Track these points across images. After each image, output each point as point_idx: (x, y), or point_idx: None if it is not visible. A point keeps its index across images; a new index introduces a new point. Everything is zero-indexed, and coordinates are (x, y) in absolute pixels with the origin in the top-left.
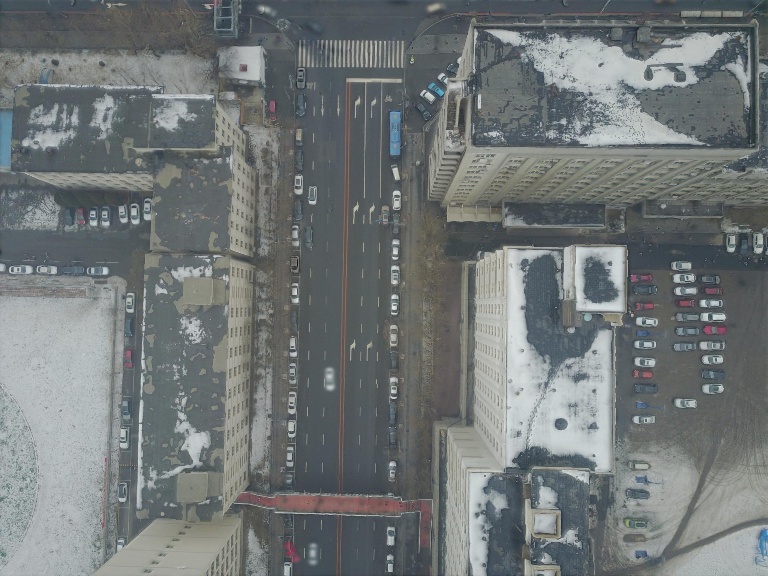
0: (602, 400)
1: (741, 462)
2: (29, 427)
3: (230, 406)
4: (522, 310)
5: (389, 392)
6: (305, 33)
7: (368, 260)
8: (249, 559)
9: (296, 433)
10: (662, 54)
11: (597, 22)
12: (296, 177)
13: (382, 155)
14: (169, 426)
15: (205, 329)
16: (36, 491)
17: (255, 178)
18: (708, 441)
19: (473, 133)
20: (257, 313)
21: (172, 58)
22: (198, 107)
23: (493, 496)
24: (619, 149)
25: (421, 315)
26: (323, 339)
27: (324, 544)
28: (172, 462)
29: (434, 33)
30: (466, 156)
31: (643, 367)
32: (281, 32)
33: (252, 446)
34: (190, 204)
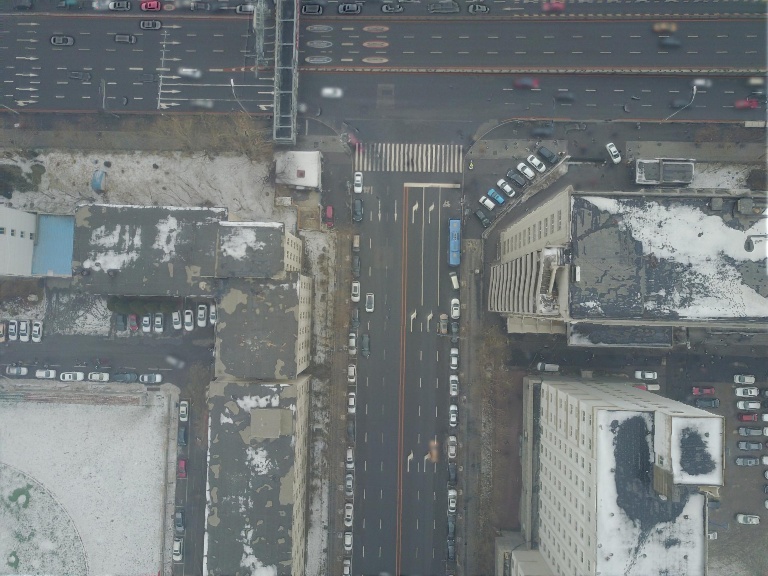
0: (694, 566)
1: None
2: (80, 537)
3: (293, 532)
4: (612, 473)
5: (447, 505)
6: (362, 136)
7: (426, 369)
8: None
9: (352, 545)
10: (763, 224)
11: (697, 192)
12: (353, 284)
13: (440, 261)
14: (234, 559)
15: (271, 460)
16: None
17: (311, 284)
18: None
19: (569, 303)
20: (313, 422)
21: (227, 161)
22: (267, 235)
23: None
24: (720, 323)
25: (480, 426)
26: (380, 449)
27: None
28: None
29: (493, 138)
30: None
31: None
32: (338, 135)
33: (308, 558)
34: (256, 331)
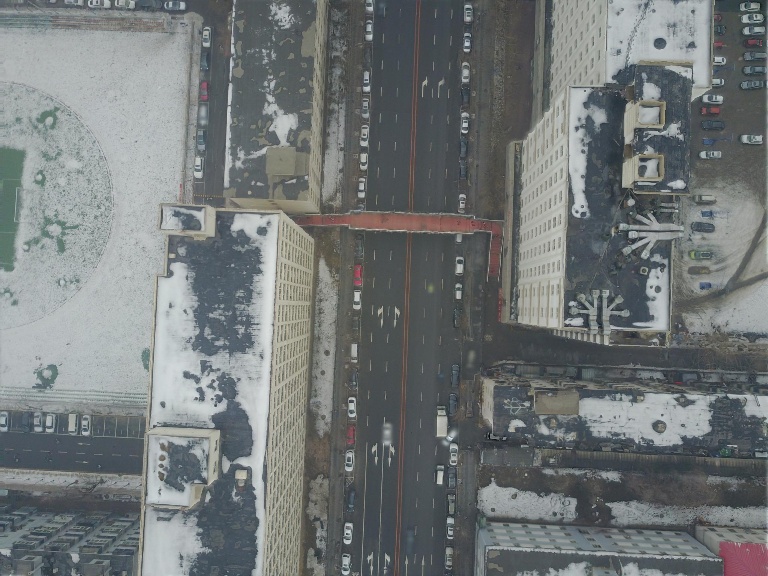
0: (700, 20)
1: None
2: (105, 157)
3: (313, 105)
4: None
5: (460, 127)
6: None
7: (441, 0)
8: (319, 287)
9: (368, 166)
10: None
11: None
12: None
13: None
14: (257, 108)
15: (294, 15)
16: (110, 219)
17: None
18: None
19: None
20: (331, 50)
21: None
22: None
23: (592, 111)
24: None
25: (493, 53)
26: (395, 76)
27: (393, 274)
28: (260, 143)
29: None
30: None
31: (711, 104)
32: None
33: (324, 178)
34: None
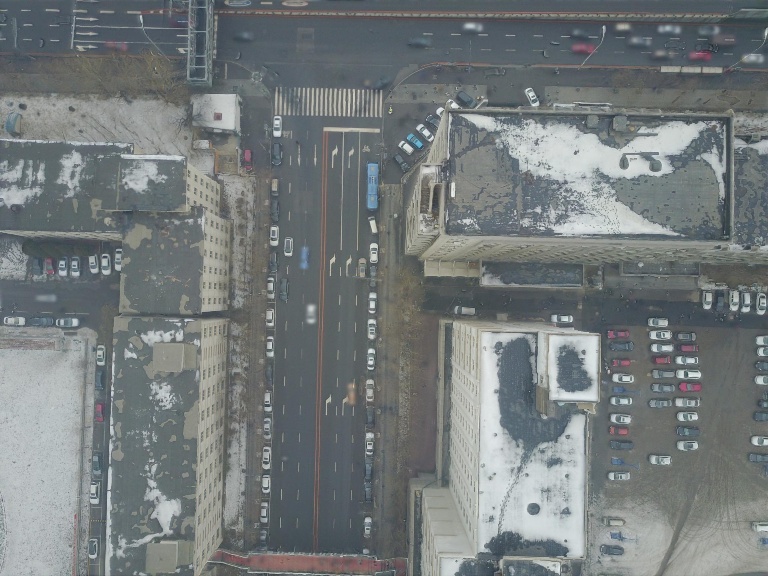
0: (574, 485)
1: (714, 518)
2: None
3: (202, 469)
4: (495, 394)
5: (365, 447)
6: (282, 80)
7: (344, 313)
8: None
9: (270, 488)
10: (638, 142)
11: (573, 109)
12: (272, 228)
13: (359, 206)
14: (138, 494)
15: (176, 395)
16: (4, 547)
17: (230, 229)
18: (682, 497)
19: (447, 220)
20: (231, 366)
21: (145, 104)
22: (169, 169)
23: None
24: (594, 239)
25: (398, 369)
26: (298, 393)
27: None
28: (141, 530)
29: (413, 82)
30: (440, 239)
31: (619, 423)
32: None
33: (226, 501)
34: (161, 266)
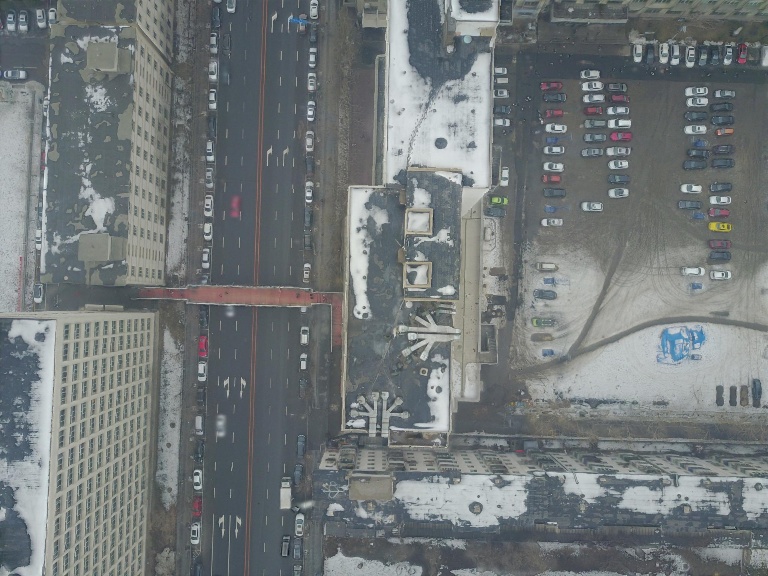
0: (480, 120)
1: (645, 264)
2: None
3: (138, 184)
4: (405, 34)
5: (304, 196)
6: None
7: (286, 68)
8: (164, 359)
9: (212, 236)
10: None
11: None
12: None
13: None
14: (73, 192)
15: (110, 98)
16: None
17: None
18: (613, 244)
19: None
20: (175, 119)
21: None
22: None
23: (374, 211)
24: None
25: (337, 122)
26: (240, 145)
27: (239, 345)
28: (76, 227)
29: None
30: None
31: (552, 171)
32: None
33: (168, 249)
34: None
